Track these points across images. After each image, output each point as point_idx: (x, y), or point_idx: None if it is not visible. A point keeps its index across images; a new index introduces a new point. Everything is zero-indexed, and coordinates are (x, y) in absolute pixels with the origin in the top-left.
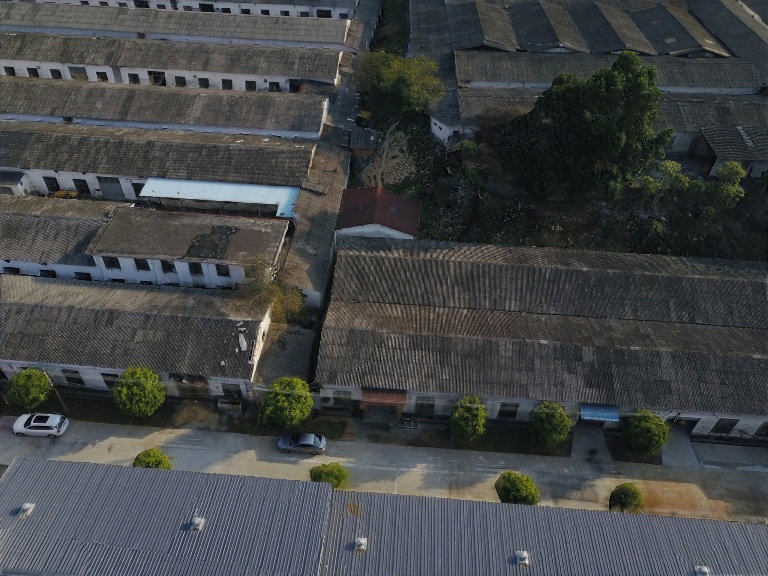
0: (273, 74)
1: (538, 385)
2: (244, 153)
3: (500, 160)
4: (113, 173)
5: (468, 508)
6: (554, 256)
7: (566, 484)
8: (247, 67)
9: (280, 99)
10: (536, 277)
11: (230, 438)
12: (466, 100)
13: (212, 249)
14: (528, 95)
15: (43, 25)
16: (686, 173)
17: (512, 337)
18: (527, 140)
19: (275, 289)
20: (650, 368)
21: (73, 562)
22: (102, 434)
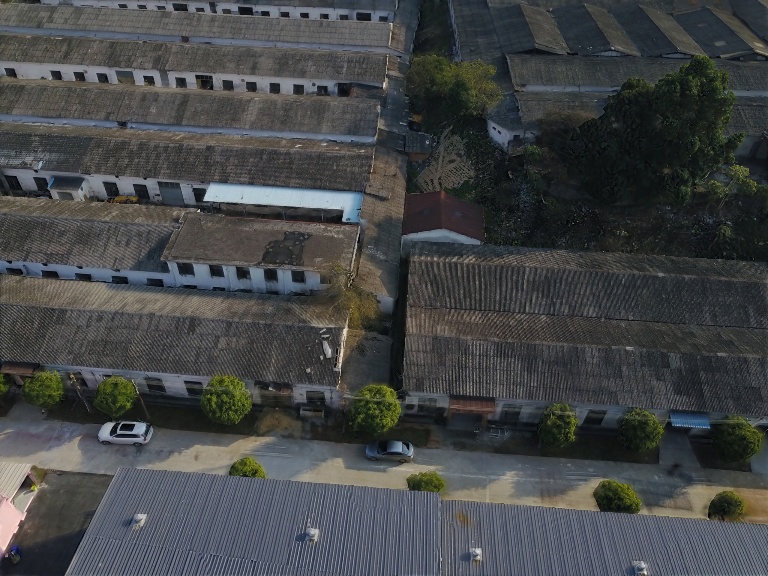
0: (322, 78)
1: (627, 392)
2: (305, 158)
3: (562, 164)
4: (175, 178)
5: (577, 517)
6: (626, 261)
7: (658, 492)
8: (295, 71)
9: (335, 103)
10: (612, 283)
11: (316, 446)
12: (526, 104)
13: (287, 255)
14: (587, 99)
15: (87, 29)
16: (749, 177)
17: (597, 344)
18: (596, 145)
19: (352, 295)
20: (738, 375)
21: (194, 574)
22: (187, 442)
